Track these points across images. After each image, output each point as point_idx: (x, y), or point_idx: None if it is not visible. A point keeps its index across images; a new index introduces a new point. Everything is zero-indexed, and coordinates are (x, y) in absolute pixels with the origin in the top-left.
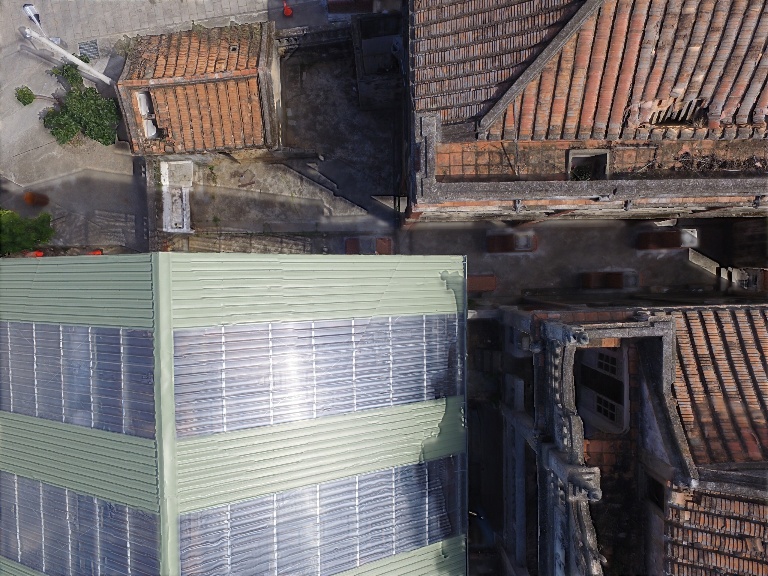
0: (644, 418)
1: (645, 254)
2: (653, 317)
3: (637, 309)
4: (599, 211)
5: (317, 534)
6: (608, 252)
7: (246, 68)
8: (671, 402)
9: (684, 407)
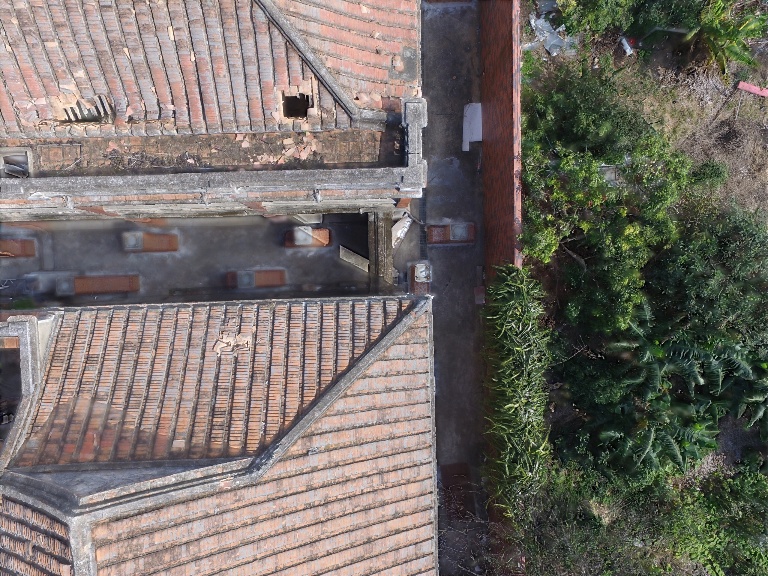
0: None
1: (294, 252)
2: (11, 317)
3: (53, 309)
4: (138, 209)
5: None
6: (256, 250)
7: None
8: (25, 403)
9: (43, 408)
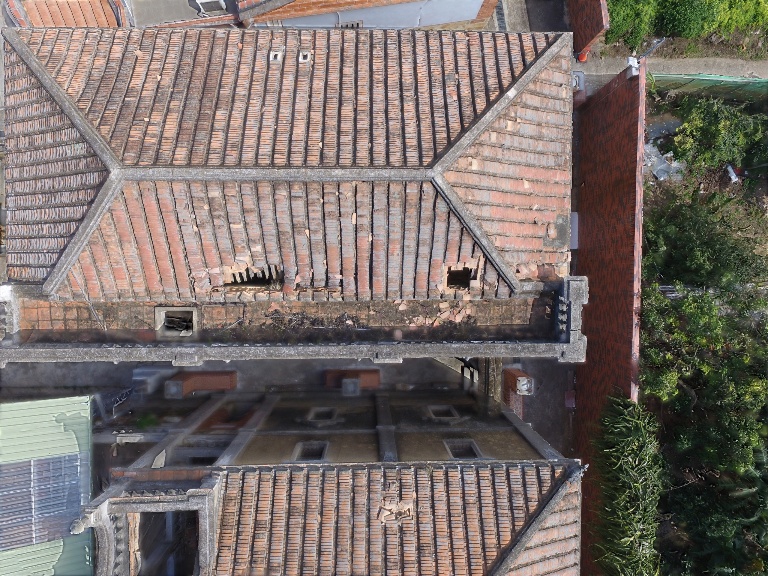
0: None
1: None
2: (190, 491)
3: (215, 468)
4: None
5: None
6: None
7: None
8: None
9: None
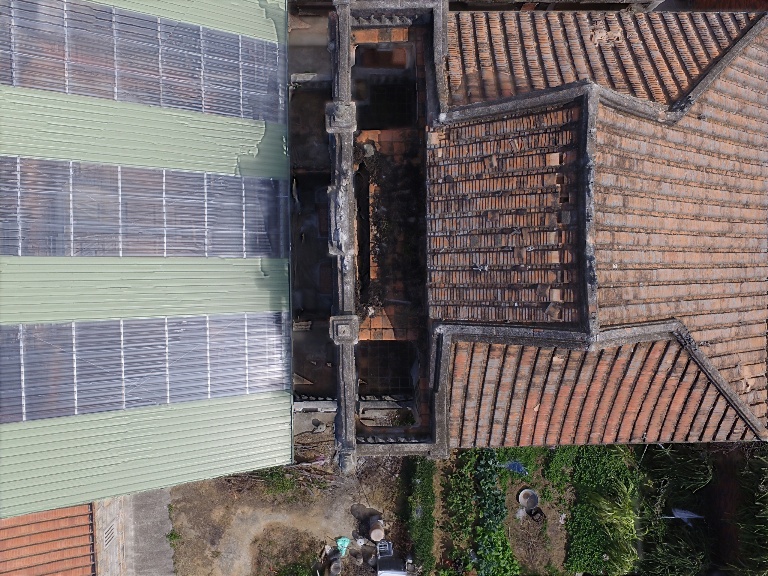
0: (426, 101)
1: None
2: None
3: None
4: None
5: (119, 213)
6: None
7: None
8: (440, 69)
9: (453, 76)
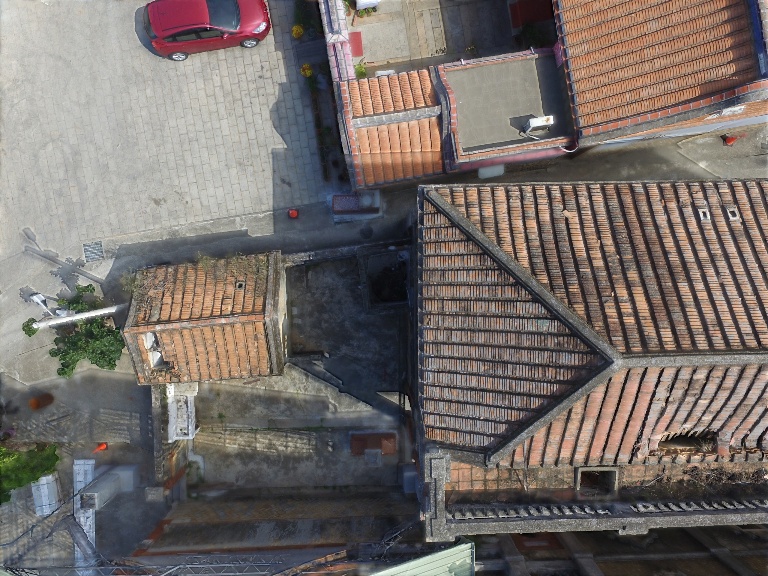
0: None
1: None
2: None
3: None
4: None
5: None
6: None
7: (252, 310)
8: None
9: None
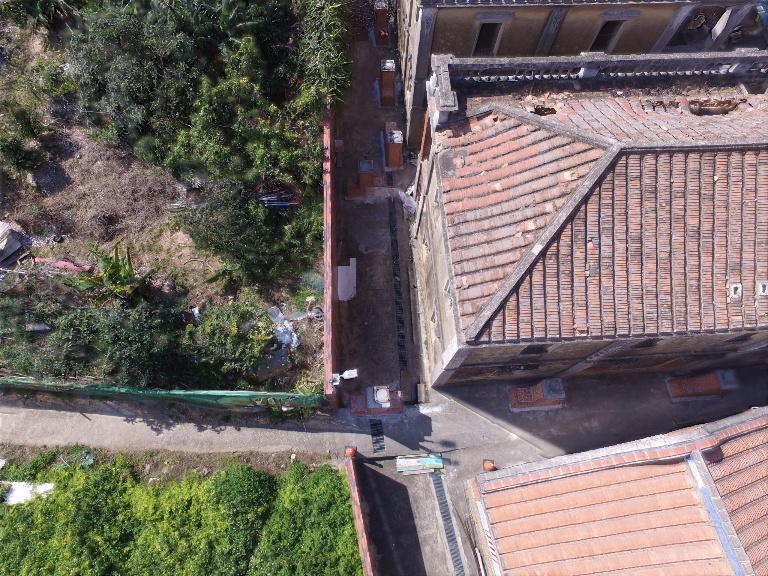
0: None
1: None
2: None
3: (694, 1)
4: None
5: None
6: None
7: None
8: None
9: None
